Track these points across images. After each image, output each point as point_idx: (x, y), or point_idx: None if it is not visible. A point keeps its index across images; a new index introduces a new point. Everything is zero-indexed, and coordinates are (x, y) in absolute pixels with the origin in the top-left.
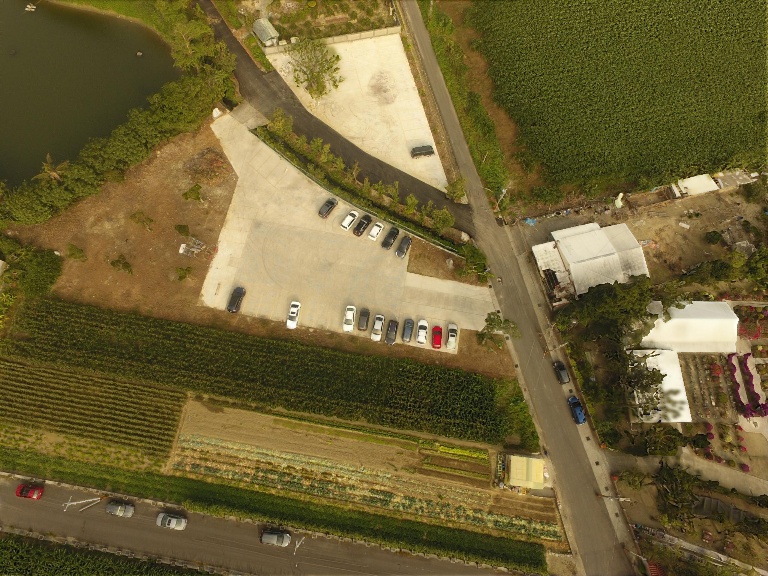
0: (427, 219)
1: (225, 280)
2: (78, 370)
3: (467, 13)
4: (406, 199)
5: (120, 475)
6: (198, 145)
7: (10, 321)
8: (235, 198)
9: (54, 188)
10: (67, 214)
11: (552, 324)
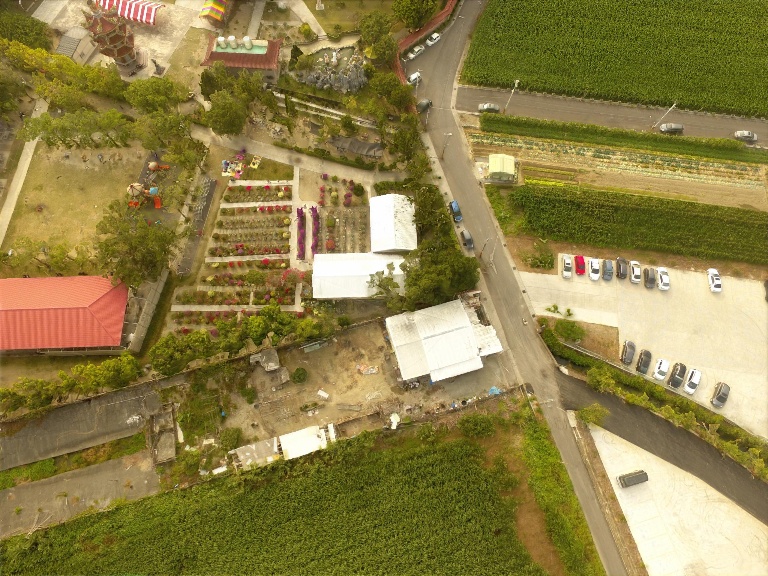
0: None
1: None
2: None
3: None
4: None
5: None
6: None
7: None
8: None
9: None
10: None
11: None
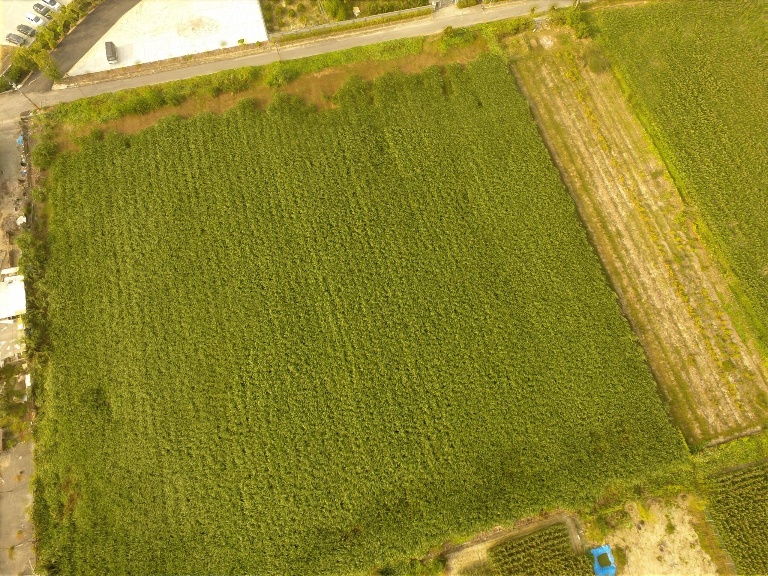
0: None
1: None
2: None
3: (292, 96)
4: None
5: None
6: None
7: None
8: None
9: None
10: None
11: None
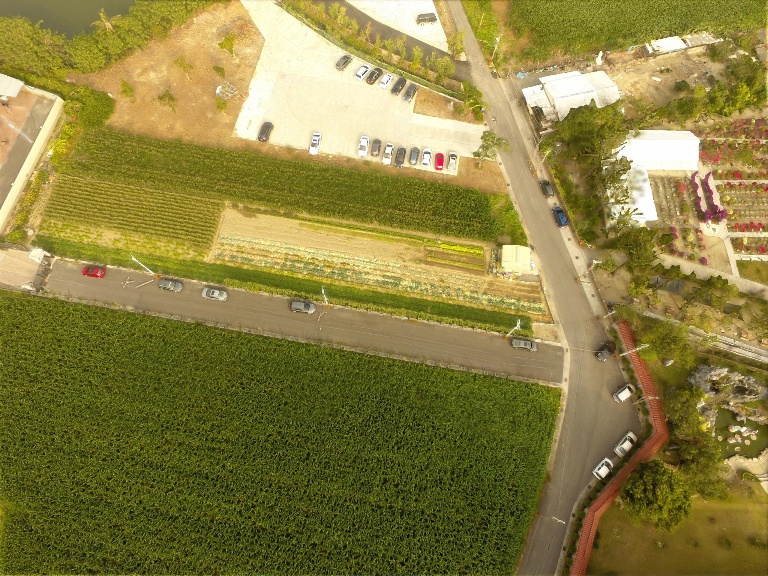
0: (431, 73)
1: (255, 118)
2: (131, 182)
3: None
4: (412, 52)
5: (170, 262)
6: (229, 14)
7: (71, 147)
8: (263, 55)
9: (109, 35)
10: (117, 66)
11: (539, 153)
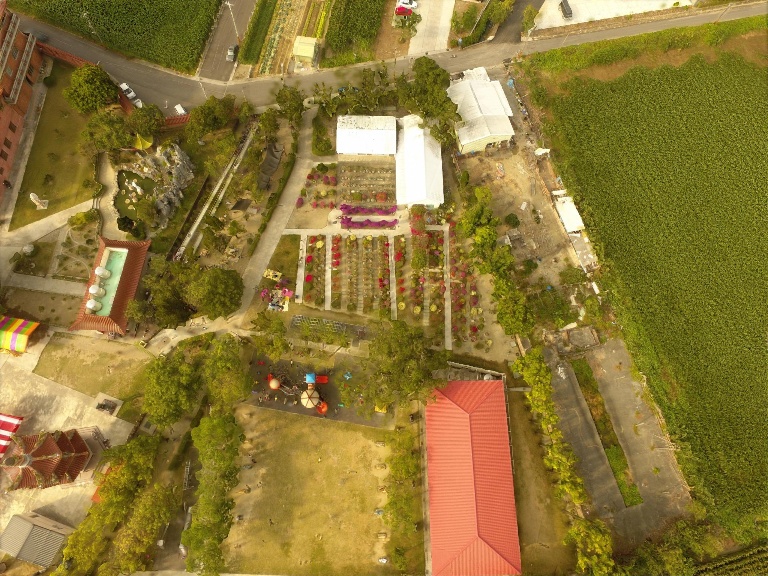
0: None
1: None
2: None
3: (734, 54)
4: None
5: None
6: None
7: None
8: None
9: None
10: None
11: None
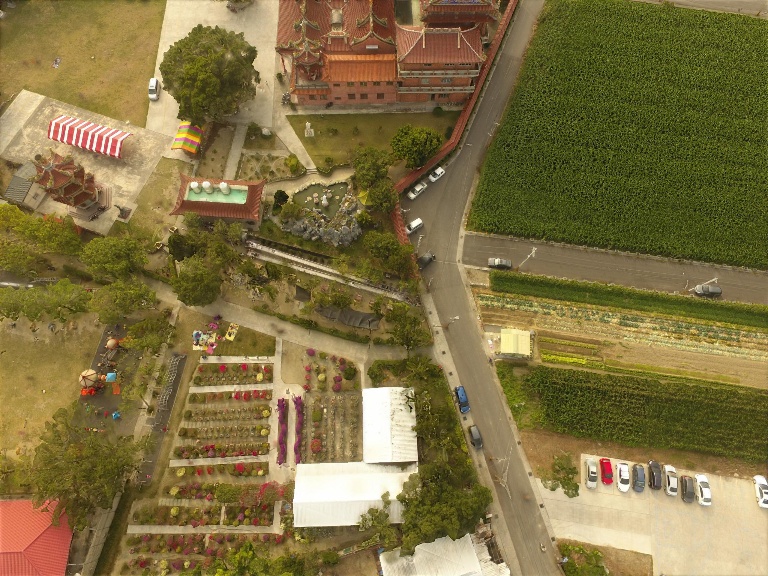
0: None
1: None
2: None
3: None
4: None
5: None
6: None
7: None
8: None
9: None
10: None
11: None
